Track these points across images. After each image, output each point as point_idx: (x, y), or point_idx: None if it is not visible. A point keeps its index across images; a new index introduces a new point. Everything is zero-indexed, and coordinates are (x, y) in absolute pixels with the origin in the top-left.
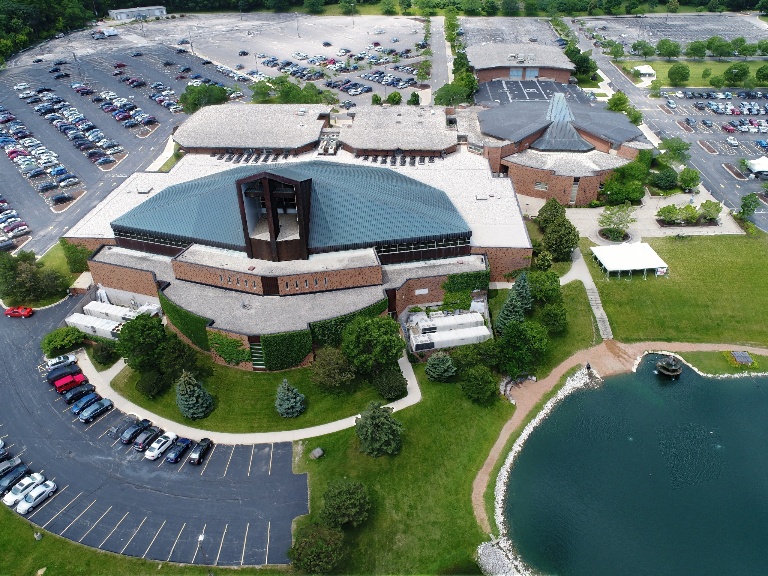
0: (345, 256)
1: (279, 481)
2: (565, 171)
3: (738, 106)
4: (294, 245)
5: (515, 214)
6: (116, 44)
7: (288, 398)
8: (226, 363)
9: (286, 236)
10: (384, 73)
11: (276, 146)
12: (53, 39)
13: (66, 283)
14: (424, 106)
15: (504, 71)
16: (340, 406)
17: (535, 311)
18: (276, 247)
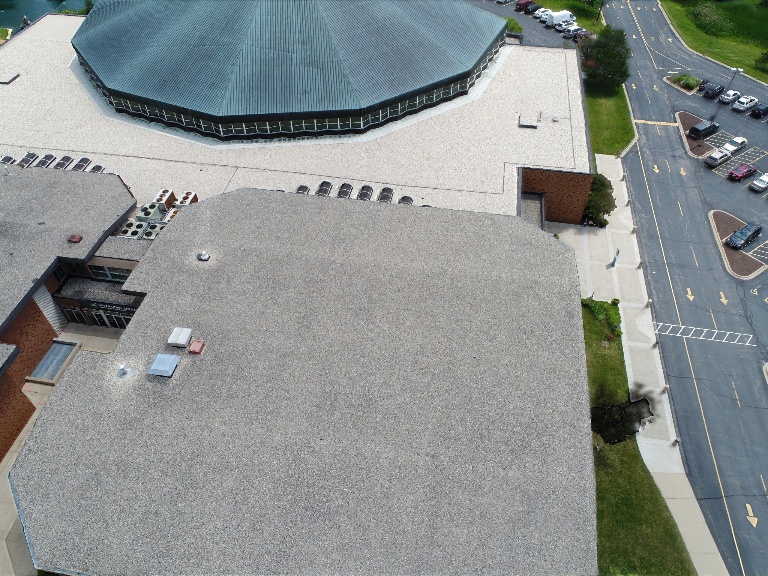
0: None
1: None
2: None
3: None
4: None
5: (4, 50)
6: None
7: None
8: None
9: None
10: None
11: (291, 194)
12: None
13: None
14: None
15: None
16: None
17: None
18: None
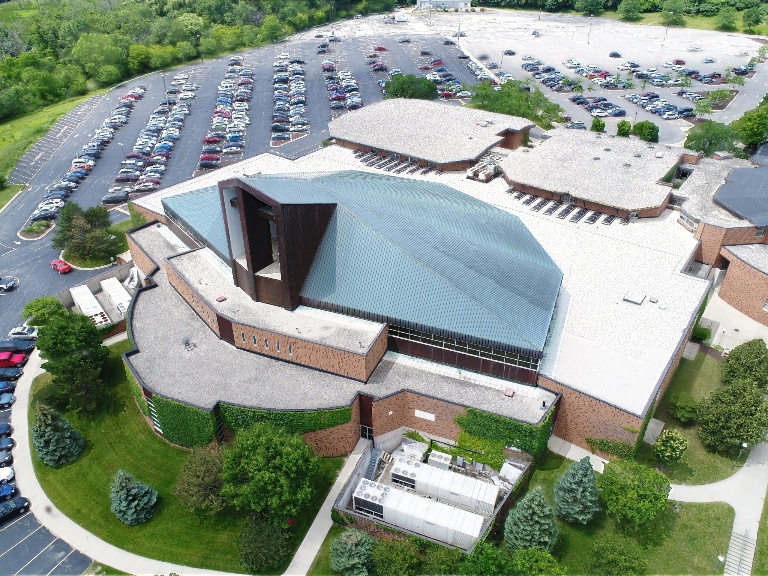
0: (338, 323)
1: None
2: None
3: None
4: (276, 286)
5: (666, 344)
6: (397, 29)
7: (120, 497)
8: None
9: (272, 271)
10: (660, 97)
11: (420, 156)
12: (350, 19)
13: (122, 250)
14: (660, 145)
15: None
16: (188, 540)
17: (602, 528)
18: (254, 282)
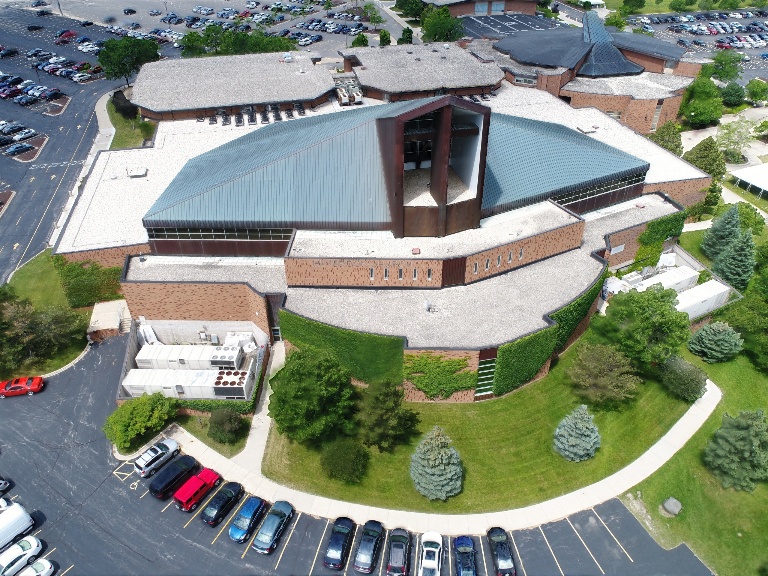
0: (524, 216)
1: (658, 569)
2: (641, 94)
3: (707, 27)
4: (467, 208)
5: (646, 143)
6: None
7: None
8: (426, 399)
9: (453, 197)
10: None
11: (287, 99)
12: None
13: None
14: None
15: (469, 6)
16: (634, 426)
17: None
18: (445, 214)
